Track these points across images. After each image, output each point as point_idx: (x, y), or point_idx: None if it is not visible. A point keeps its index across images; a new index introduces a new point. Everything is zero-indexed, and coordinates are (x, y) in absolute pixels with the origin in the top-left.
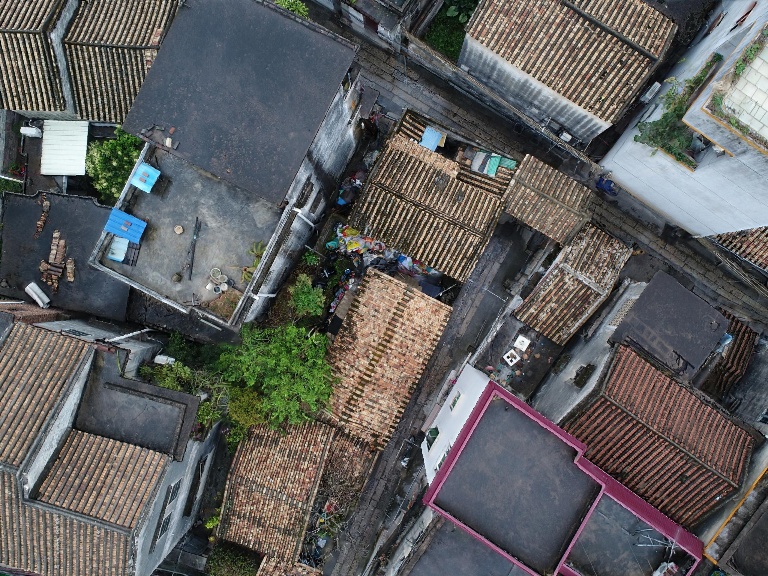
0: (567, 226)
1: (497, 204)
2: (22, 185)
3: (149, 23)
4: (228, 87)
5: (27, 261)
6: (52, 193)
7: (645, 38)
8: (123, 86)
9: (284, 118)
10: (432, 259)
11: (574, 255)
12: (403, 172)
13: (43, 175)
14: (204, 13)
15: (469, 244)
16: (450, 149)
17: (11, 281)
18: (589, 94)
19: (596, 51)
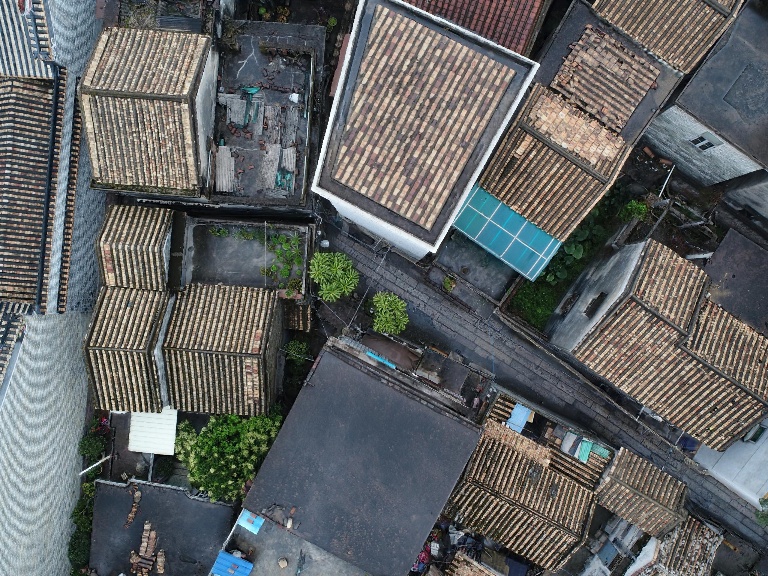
0: (661, 523)
1: (590, 497)
2: (109, 460)
3: (247, 321)
4: (350, 468)
5: (117, 551)
6: (144, 484)
7: (757, 377)
8: (220, 384)
9: (406, 500)
10: (523, 550)
11: (667, 550)
12: (497, 465)
13: (130, 451)
14: (328, 392)
15: (563, 542)
16: (539, 423)
17: (100, 570)
18: (697, 423)
19: (707, 389)
